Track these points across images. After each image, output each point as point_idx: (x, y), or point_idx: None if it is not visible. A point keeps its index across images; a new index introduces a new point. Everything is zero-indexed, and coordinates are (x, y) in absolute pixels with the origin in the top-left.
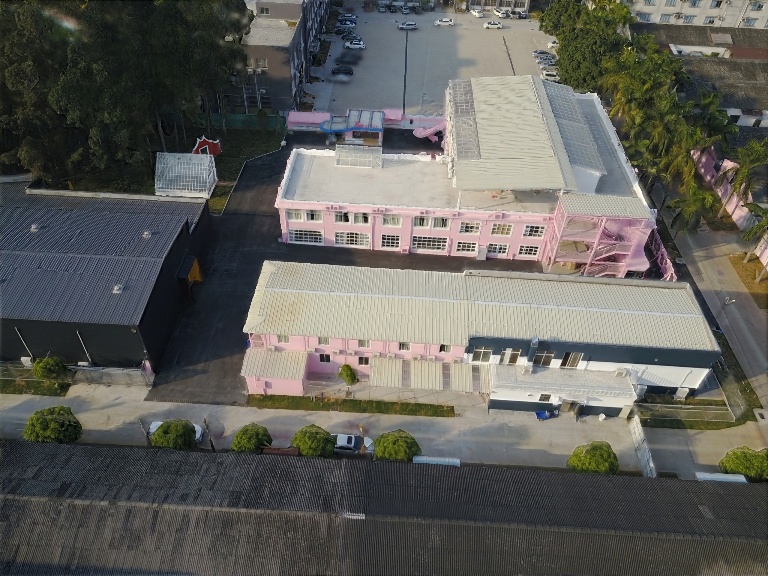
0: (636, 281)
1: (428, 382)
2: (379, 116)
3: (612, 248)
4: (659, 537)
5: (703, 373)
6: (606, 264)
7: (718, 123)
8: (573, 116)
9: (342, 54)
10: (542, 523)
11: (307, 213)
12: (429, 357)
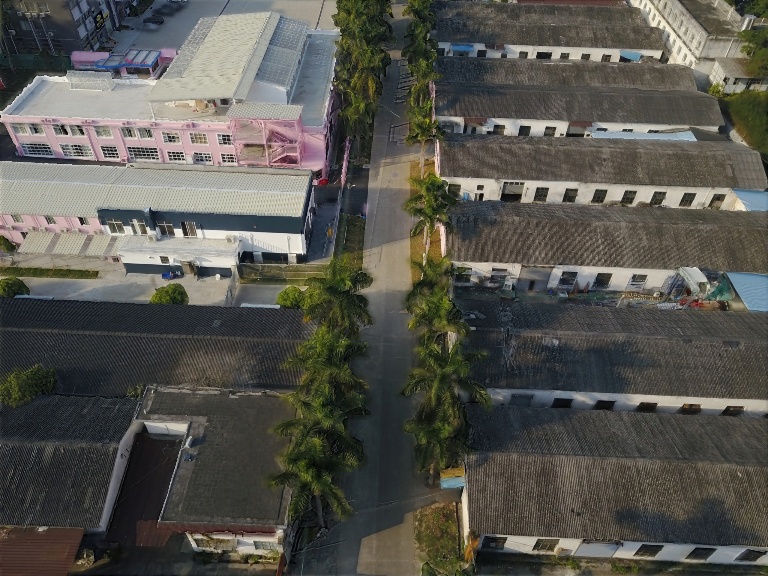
0: (268, 169)
1: (68, 249)
2: (155, 54)
3: (283, 150)
4: (160, 337)
5: (299, 238)
6: (284, 166)
7: (420, 49)
8: (292, 45)
9: (163, 6)
10: (73, 329)
11: (30, 127)
12: (73, 229)
